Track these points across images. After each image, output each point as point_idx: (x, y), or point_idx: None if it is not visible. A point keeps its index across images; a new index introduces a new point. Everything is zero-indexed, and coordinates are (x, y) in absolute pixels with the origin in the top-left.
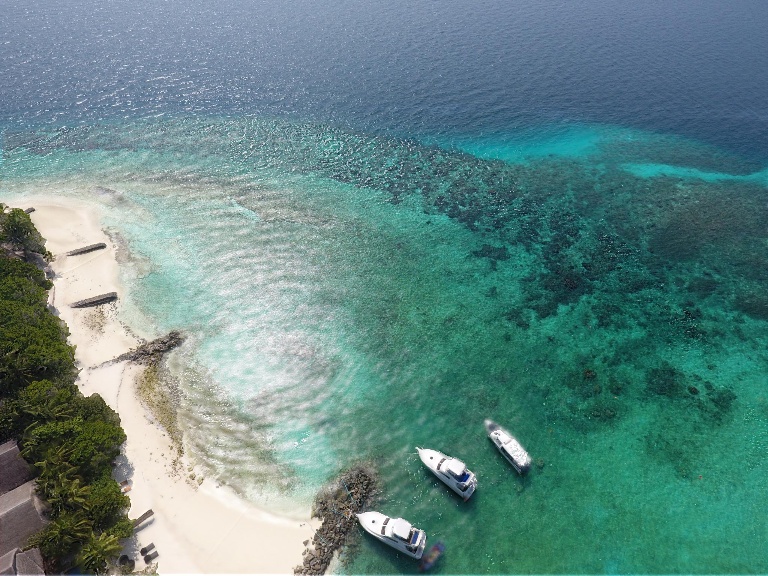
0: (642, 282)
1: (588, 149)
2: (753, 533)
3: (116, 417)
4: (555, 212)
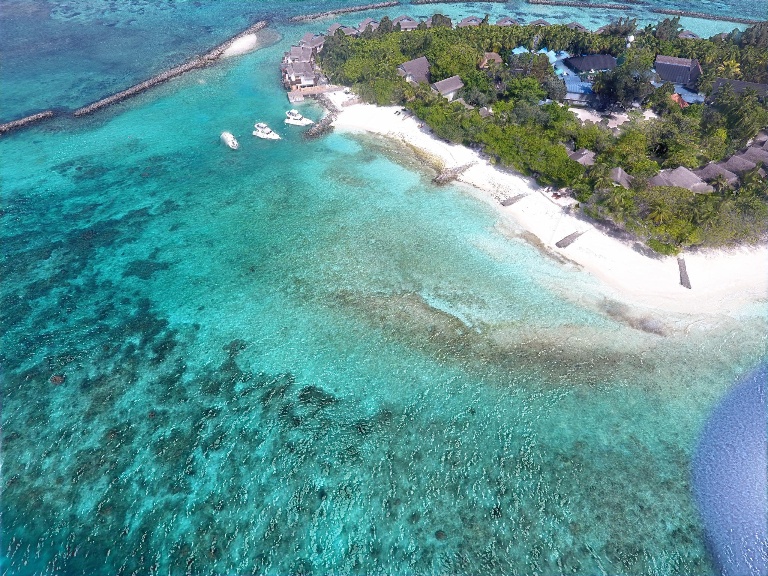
0: (5, 241)
1: None
2: None
3: None
4: None
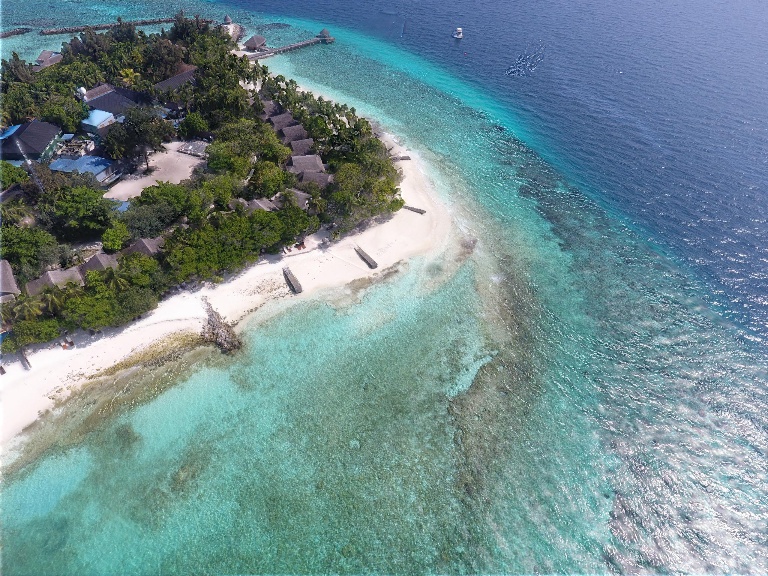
0: None
1: None
2: None
3: (122, 319)
4: None
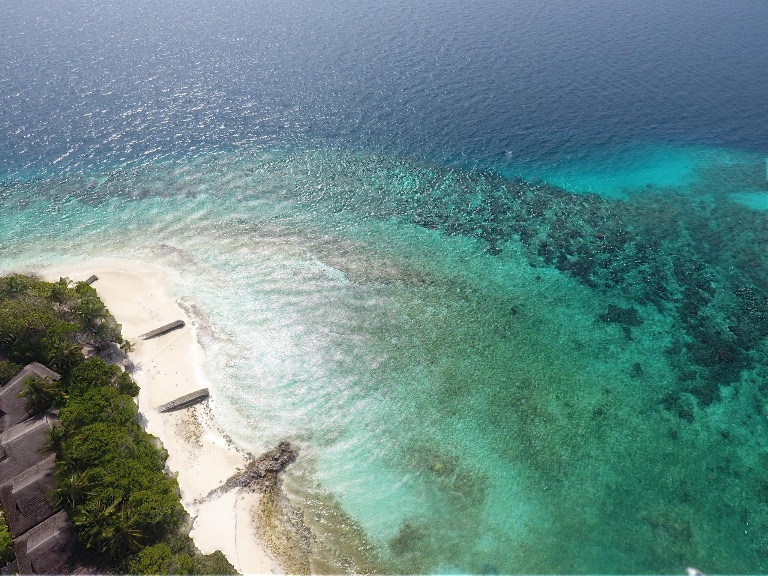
0: None
1: (687, 176)
2: None
3: None
4: (676, 259)
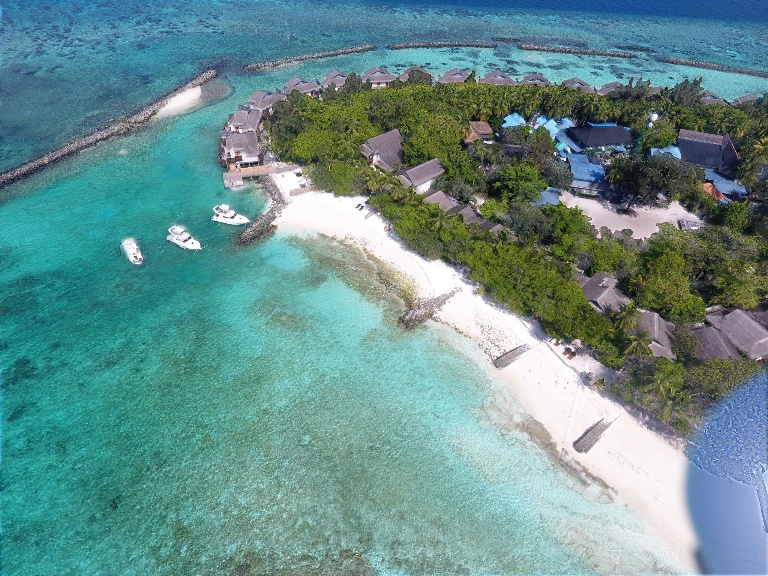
0: None
1: None
2: (2, 226)
3: None
4: None
